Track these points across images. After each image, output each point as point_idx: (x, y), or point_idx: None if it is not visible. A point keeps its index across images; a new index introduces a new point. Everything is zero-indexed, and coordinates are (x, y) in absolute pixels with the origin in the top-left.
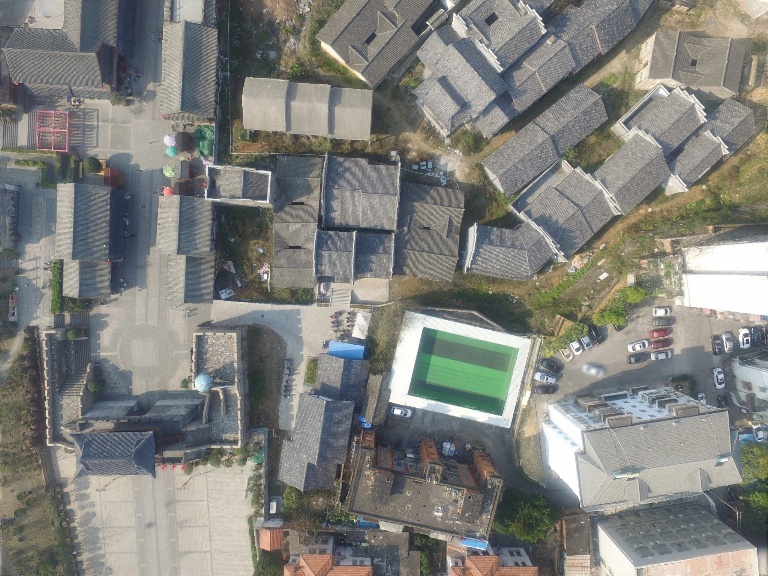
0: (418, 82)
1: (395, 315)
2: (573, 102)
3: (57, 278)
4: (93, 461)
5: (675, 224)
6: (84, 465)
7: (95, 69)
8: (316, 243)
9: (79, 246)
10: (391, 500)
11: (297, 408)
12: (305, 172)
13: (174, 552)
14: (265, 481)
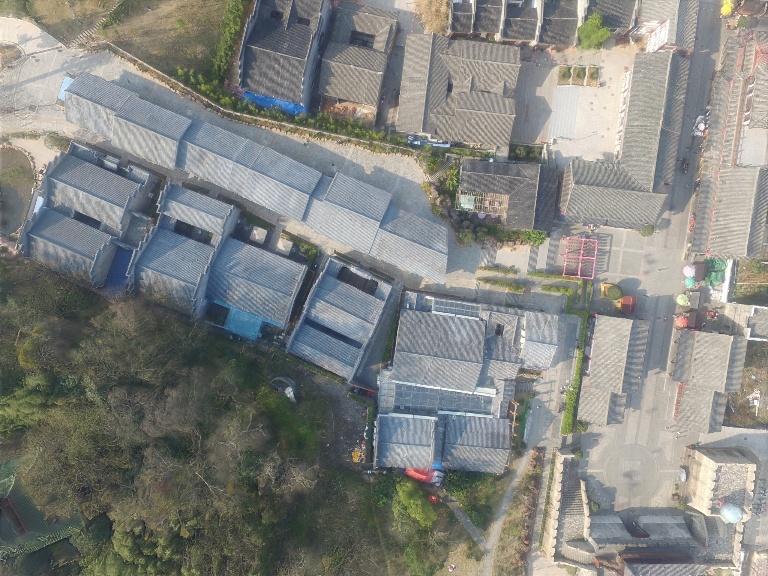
0: None
1: None
2: None
3: (573, 402)
4: None
5: None
6: None
7: (656, 207)
8: None
9: (625, 380)
10: None
11: None
12: None
13: None
14: None
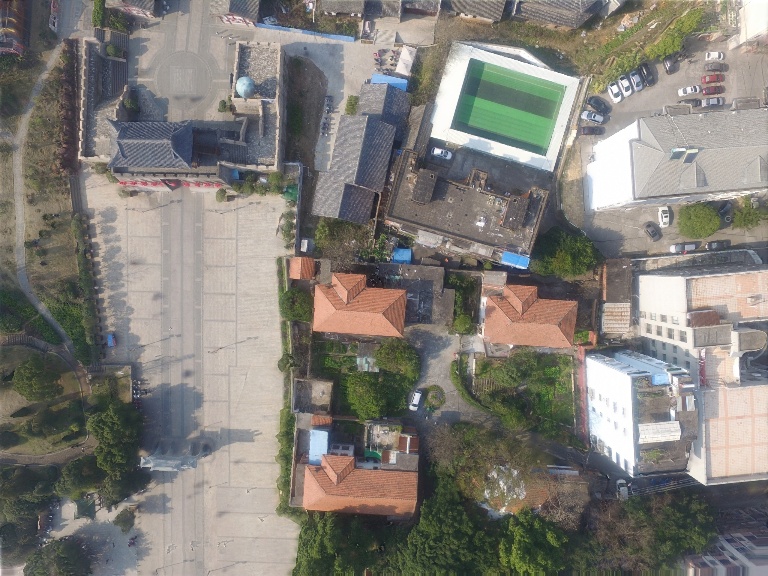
0: None
1: (441, 46)
2: None
3: None
4: (130, 140)
5: None
6: (120, 147)
7: None
8: None
9: None
10: (432, 207)
11: (337, 131)
12: None
13: (199, 293)
14: (298, 215)
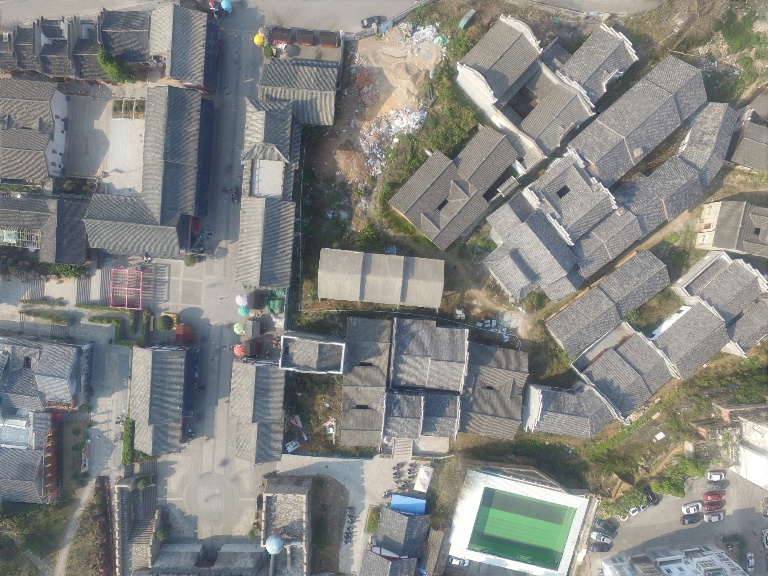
0: (485, 242)
1: (458, 473)
2: (638, 268)
3: (129, 432)
4: None
5: (730, 384)
6: None
7: (174, 239)
8: (385, 409)
9: (155, 411)
10: None
11: (361, 563)
12: (375, 336)
13: None
14: None
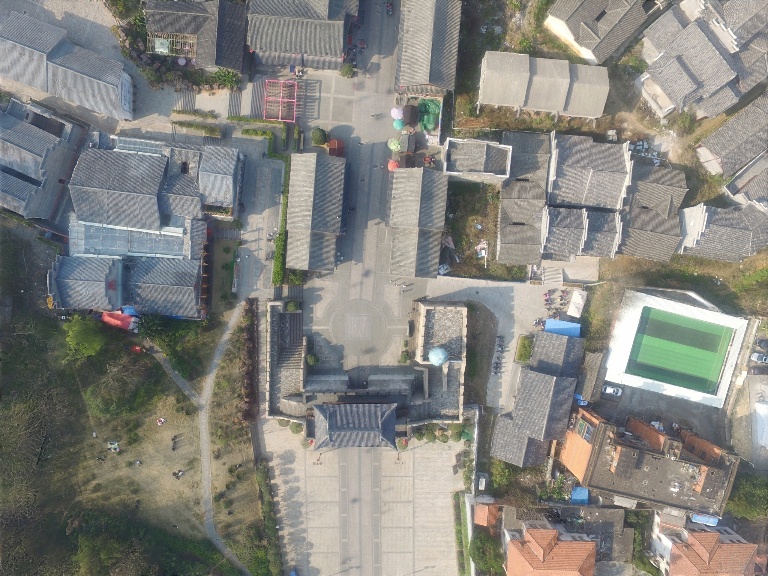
0: (637, 61)
1: (615, 293)
2: None
3: (281, 250)
4: (341, 432)
5: None
6: (329, 436)
7: (338, 38)
8: (548, 219)
9: (316, 217)
10: None
11: None
12: (533, 148)
13: (377, 527)
14: None
